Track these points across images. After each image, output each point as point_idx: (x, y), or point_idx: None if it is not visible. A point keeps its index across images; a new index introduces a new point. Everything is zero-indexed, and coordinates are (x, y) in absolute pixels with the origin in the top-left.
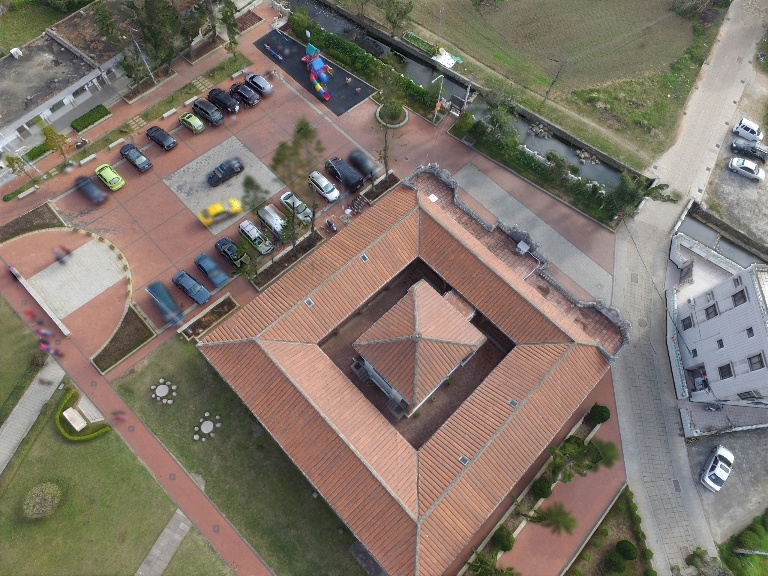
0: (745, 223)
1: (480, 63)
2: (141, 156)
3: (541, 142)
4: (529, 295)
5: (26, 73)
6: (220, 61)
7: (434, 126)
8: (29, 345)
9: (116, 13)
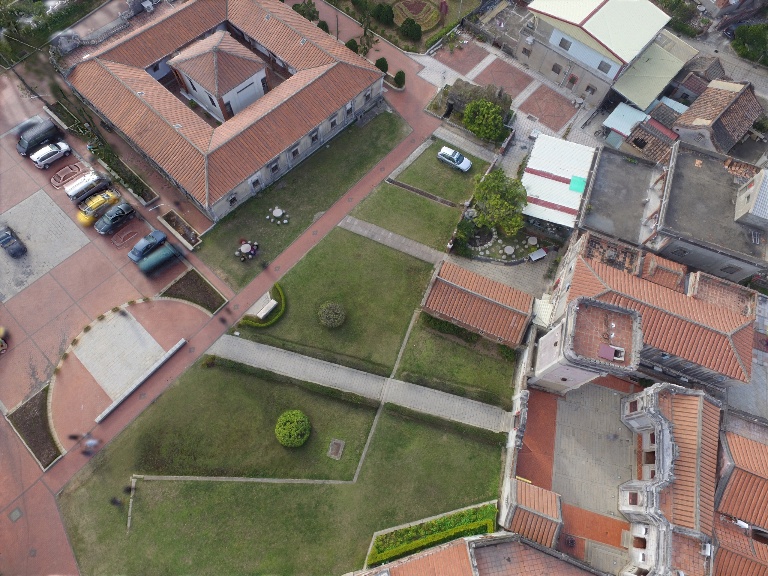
0: None
1: None
2: None
3: None
4: (189, 3)
5: None
6: None
7: None
8: (192, 375)
9: None
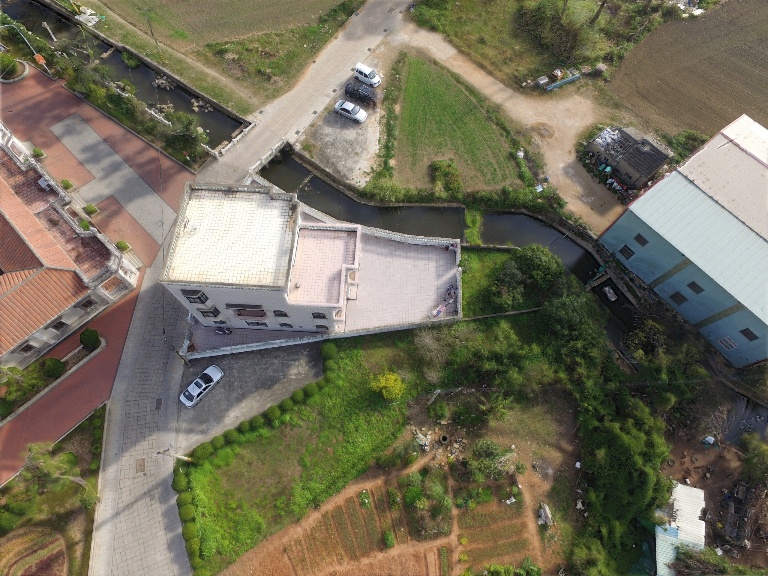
0: (333, 162)
1: (124, 20)
2: None
3: (162, 93)
4: (24, 226)
5: None
6: None
7: (52, 80)
8: None
9: None
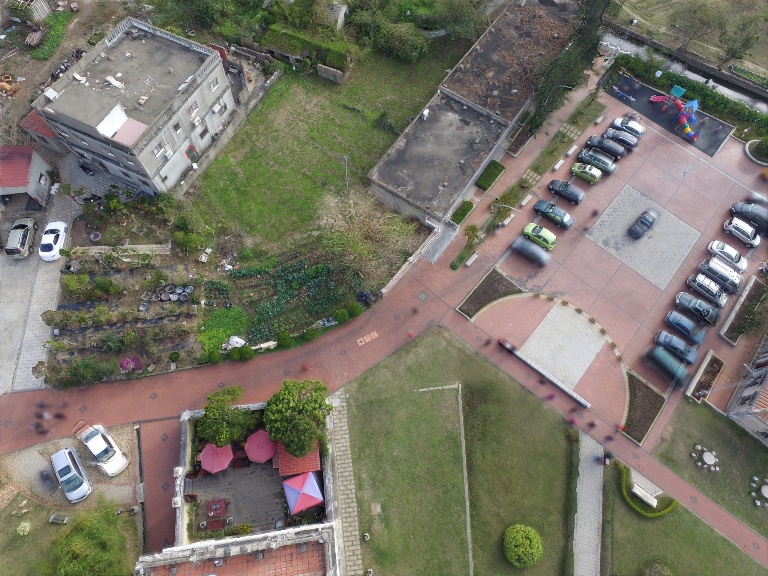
0: None
1: None
2: (566, 213)
3: None
4: None
5: (443, 135)
6: (575, 106)
7: None
8: (555, 421)
9: (492, 65)
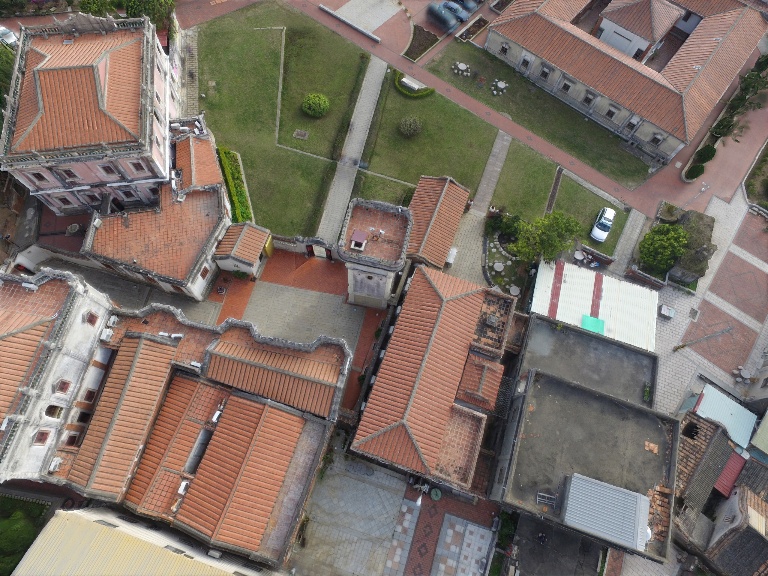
0: None
1: None
2: None
3: None
4: None
5: None
6: None
7: None
8: (354, 49)
9: None
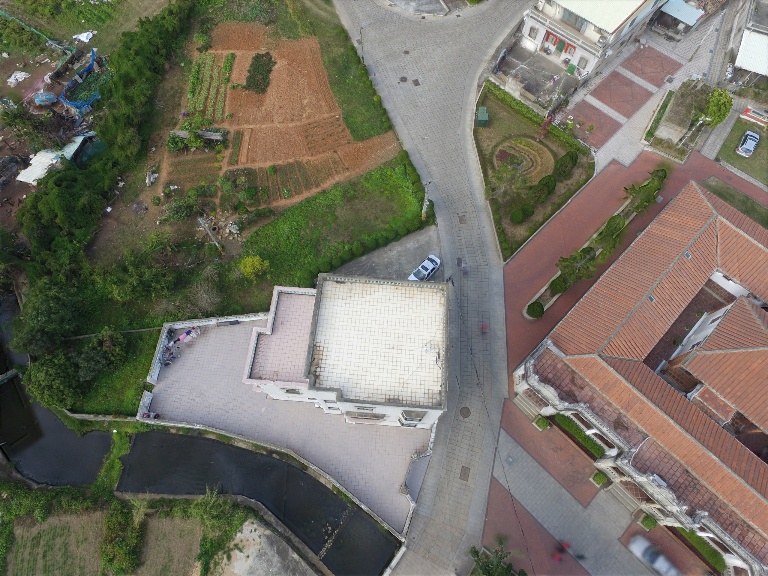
0: (285, 573)
1: None
2: None
3: None
4: (647, 412)
5: None
6: None
7: None
8: None
9: None
